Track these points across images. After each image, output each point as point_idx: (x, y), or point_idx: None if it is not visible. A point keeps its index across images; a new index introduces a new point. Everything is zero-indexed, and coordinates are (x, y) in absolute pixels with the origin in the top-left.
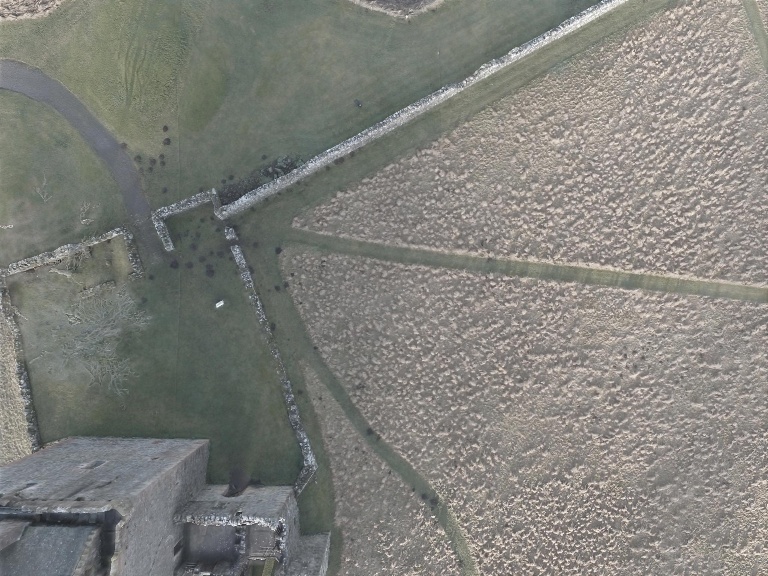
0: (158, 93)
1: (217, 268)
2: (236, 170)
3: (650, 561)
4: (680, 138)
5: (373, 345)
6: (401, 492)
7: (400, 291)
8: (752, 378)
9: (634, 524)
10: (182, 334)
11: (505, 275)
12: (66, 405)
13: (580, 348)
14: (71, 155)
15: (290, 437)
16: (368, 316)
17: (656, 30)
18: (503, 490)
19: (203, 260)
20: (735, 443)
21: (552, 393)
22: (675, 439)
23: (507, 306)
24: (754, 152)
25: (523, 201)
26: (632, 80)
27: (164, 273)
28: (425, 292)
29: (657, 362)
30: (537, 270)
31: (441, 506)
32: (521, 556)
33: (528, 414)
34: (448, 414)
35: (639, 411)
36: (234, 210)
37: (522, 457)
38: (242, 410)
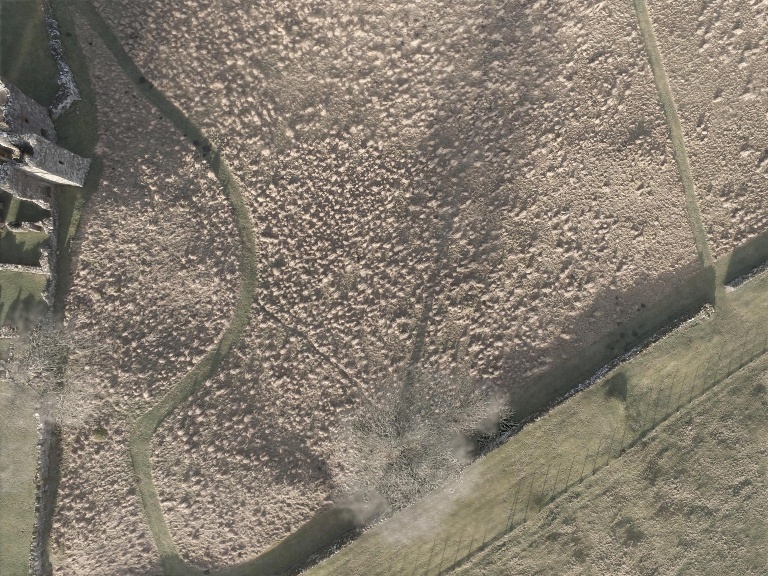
0: None
1: None
2: None
3: (428, 221)
4: None
5: None
6: (171, 136)
7: None
8: (534, 52)
9: (413, 185)
10: None
11: None
12: None
13: (361, 14)
14: None
15: (51, 68)
16: None
17: None
18: (279, 144)
19: None
20: (516, 113)
21: (332, 56)
22: (456, 107)
23: None
24: None
25: None
26: None
27: None
28: None
29: (439, 32)
30: None
31: (214, 154)
32: (297, 209)
33: (307, 75)
34: (224, 68)
35: (420, 78)
36: None
37: (300, 115)
38: (3, 41)
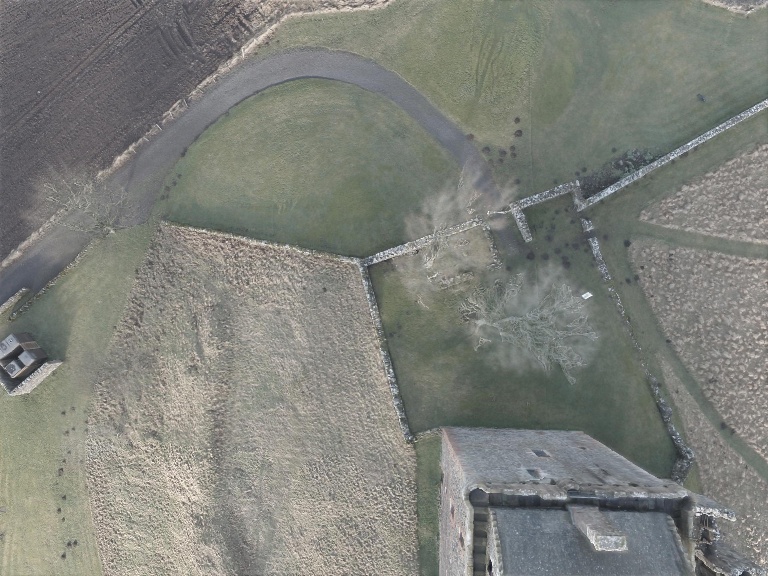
0: (511, 85)
1: (573, 260)
2: (588, 162)
3: None
4: None
5: (723, 339)
6: (759, 487)
7: (745, 285)
8: None
9: None
10: None
11: None
12: (433, 395)
13: None
14: (410, 146)
15: (661, 430)
16: (717, 310)
17: None
18: None
19: (559, 252)
20: None
21: None
22: None
23: None
24: None
25: None
26: None
27: (521, 264)
28: None
29: None
30: None
31: None
32: None
33: None
34: None
35: None
36: (594, 202)
37: None
38: (612, 402)
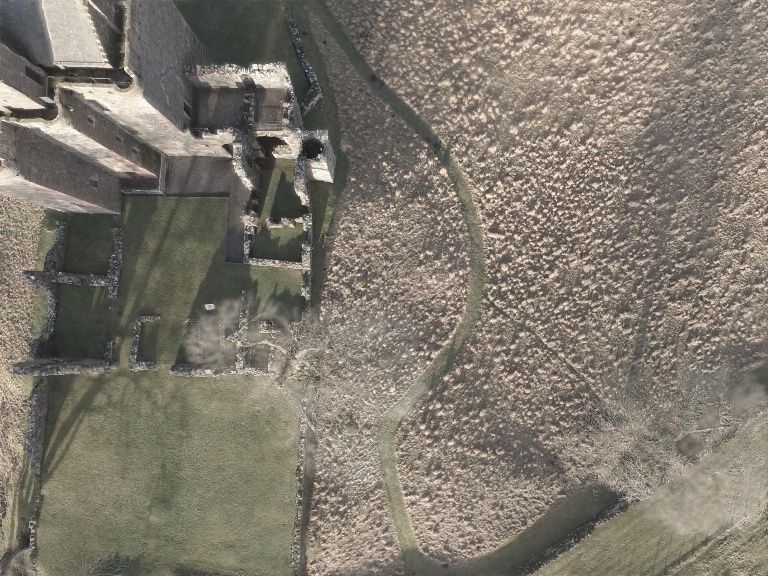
0: None
1: None
2: None
3: (646, 217)
4: None
5: None
6: (405, 133)
7: None
8: (743, 50)
9: (631, 182)
10: None
11: None
12: None
13: (578, 13)
14: None
15: (296, 66)
16: None
17: None
18: (504, 141)
19: None
20: (727, 111)
21: (551, 55)
22: (670, 105)
23: None
24: None
25: None
26: None
27: None
28: None
29: (652, 30)
30: None
31: (444, 151)
32: (522, 205)
33: (528, 73)
34: (450, 66)
35: (635, 76)
36: None
37: (522, 113)
38: (248, 40)
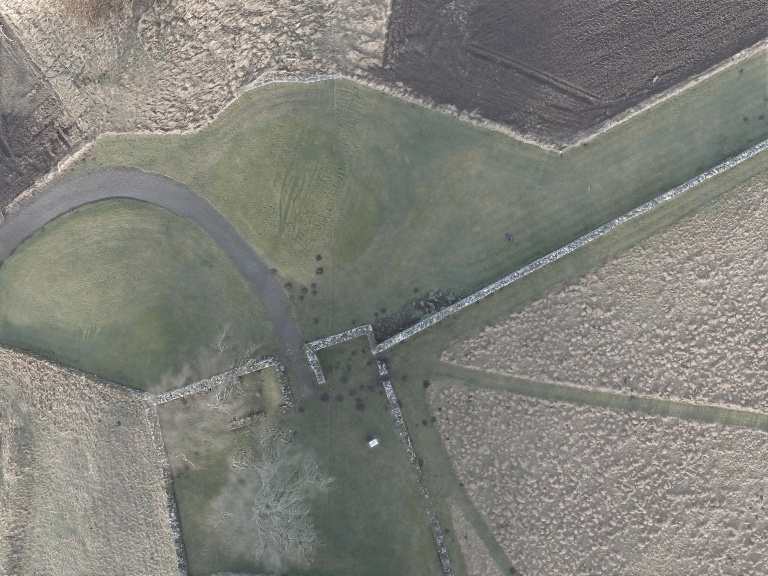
0: (313, 222)
1: (367, 402)
2: (388, 303)
3: None
4: None
5: (518, 483)
6: None
7: (545, 428)
8: None
9: None
10: (333, 470)
11: (647, 414)
12: (215, 539)
13: (718, 489)
14: (217, 276)
15: None
16: (513, 453)
17: None
18: None
19: (353, 393)
20: None
21: (689, 533)
22: None
23: (648, 445)
24: None
25: (667, 340)
26: None
27: (314, 406)
28: (569, 429)
29: None
30: (678, 409)
31: None
32: None
33: (665, 554)
34: (589, 554)
35: None
36: None
37: None
38: (393, 551)
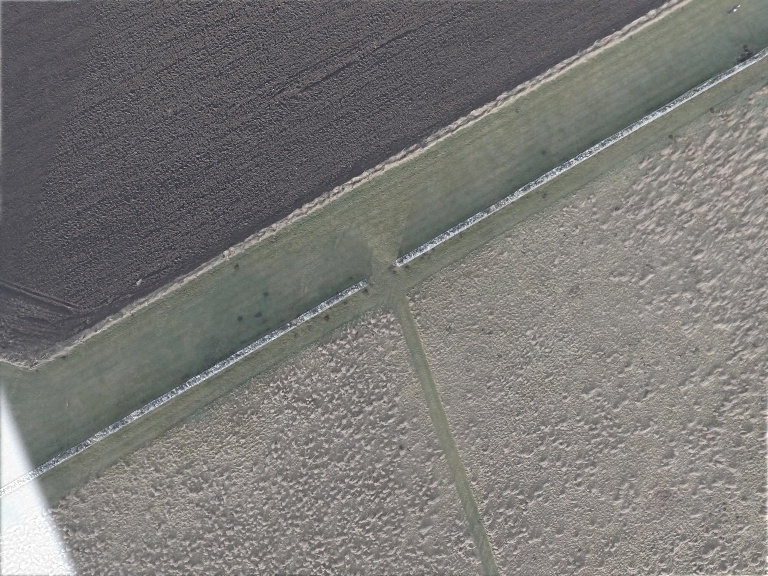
0: None
1: None
2: None
3: None
4: (330, 483)
5: None
6: None
7: None
8: None
9: None
10: None
11: None
12: None
13: None
14: None
15: None
16: None
17: (308, 367)
18: None
19: None
20: None
21: None
22: None
23: None
24: (409, 495)
25: (159, 558)
26: (280, 422)
27: None
28: None
29: None
30: None
31: None
32: None
33: None
34: None
35: None
36: None
37: None
38: None
